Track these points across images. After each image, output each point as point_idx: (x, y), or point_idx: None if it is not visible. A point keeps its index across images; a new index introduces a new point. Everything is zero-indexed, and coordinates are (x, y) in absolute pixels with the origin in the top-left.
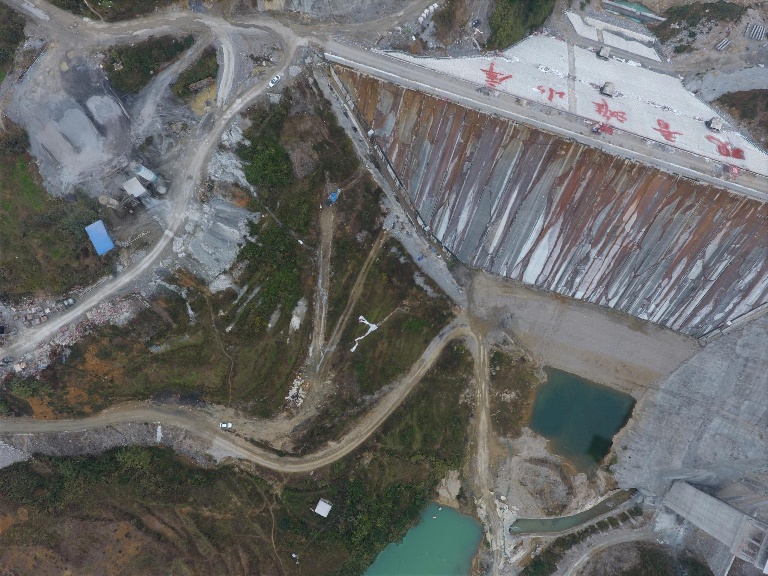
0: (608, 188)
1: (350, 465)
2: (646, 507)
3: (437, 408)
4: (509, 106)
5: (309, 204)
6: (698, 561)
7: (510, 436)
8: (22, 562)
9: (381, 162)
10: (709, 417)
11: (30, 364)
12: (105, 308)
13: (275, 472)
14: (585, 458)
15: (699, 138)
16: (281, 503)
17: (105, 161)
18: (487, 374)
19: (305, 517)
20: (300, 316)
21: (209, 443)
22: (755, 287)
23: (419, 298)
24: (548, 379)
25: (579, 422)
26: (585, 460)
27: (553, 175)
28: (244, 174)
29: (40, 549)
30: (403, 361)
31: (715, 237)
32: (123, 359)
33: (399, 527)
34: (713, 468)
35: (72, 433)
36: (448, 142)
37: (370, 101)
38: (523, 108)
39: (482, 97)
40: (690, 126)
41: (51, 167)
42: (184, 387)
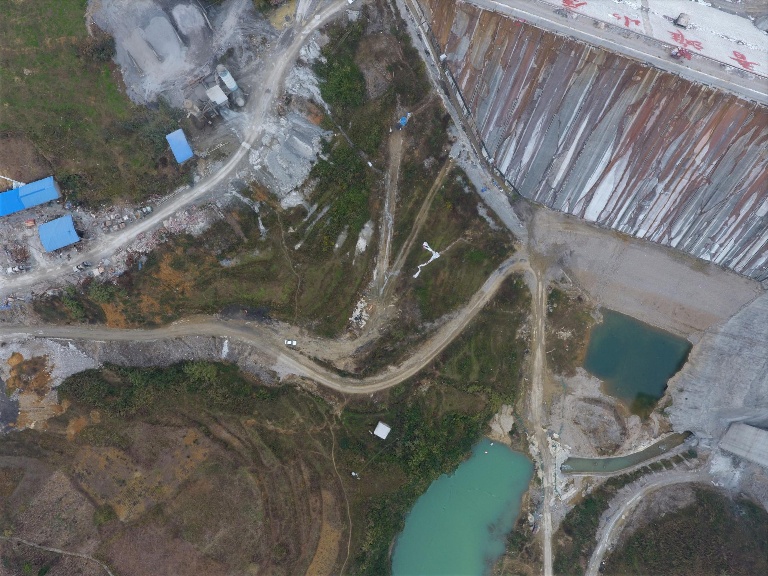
0: (682, 117)
1: (409, 390)
2: (701, 450)
3: (494, 341)
4: (587, 28)
5: (380, 126)
6: (754, 503)
7: (565, 374)
8: (94, 462)
9: (451, 89)
10: None
11: (107, 269)
12: (181, 217)
13: (336, 392)
14: (639, 401)
15: None
16: (341, 424)
17: (187, 71)
18: (544, 311)
19: (364, 439)
20: (366, 238)
21: (274, 359)
22: None
23: (481, 229)
24: (604, 320)
25: (633, 365)
26: (639, 403)
27: (626, 103)
28: (320, 91)
29: (112, 450)
30: (463, 291)
31: None
32: (195, 271)
33: (453, 457)
34: None
35: (142, 343)
36: (521, 67)
37: (445, 23)
38: (601, 31)
39: (560, 19)
40: (766, 59)
41: (135, 75)
42: (252, 302)
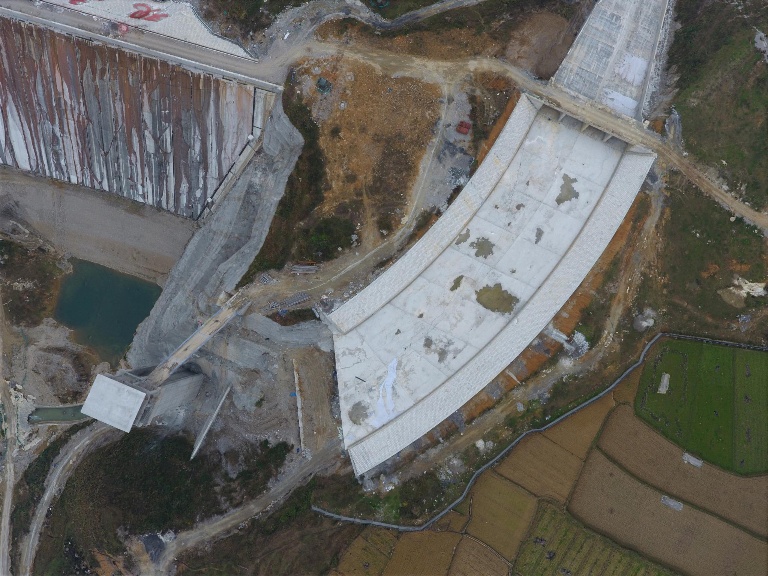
0: (26, 56)
1: None
2: None
3: None
4: None
5: None
6: (186, 439)
7: (24, 325)
8: None
9: None
10: (176, 291)
11: None
12: None
13: None
14: (110, 347)
15: (123, 4)
16: None
17: None
18: None
19: None
20: None
21: None
22: (208, 157)
23: None
24: (74, 270)
25: (109, 313)
26: (110, 349)
27: None
28: None
29: None
30: None
31: (143, 103)
32: None
33: None
34: (167, 339)
35: None
36: None
37: None
38: None
39: None
40: None
41: None
42: None
